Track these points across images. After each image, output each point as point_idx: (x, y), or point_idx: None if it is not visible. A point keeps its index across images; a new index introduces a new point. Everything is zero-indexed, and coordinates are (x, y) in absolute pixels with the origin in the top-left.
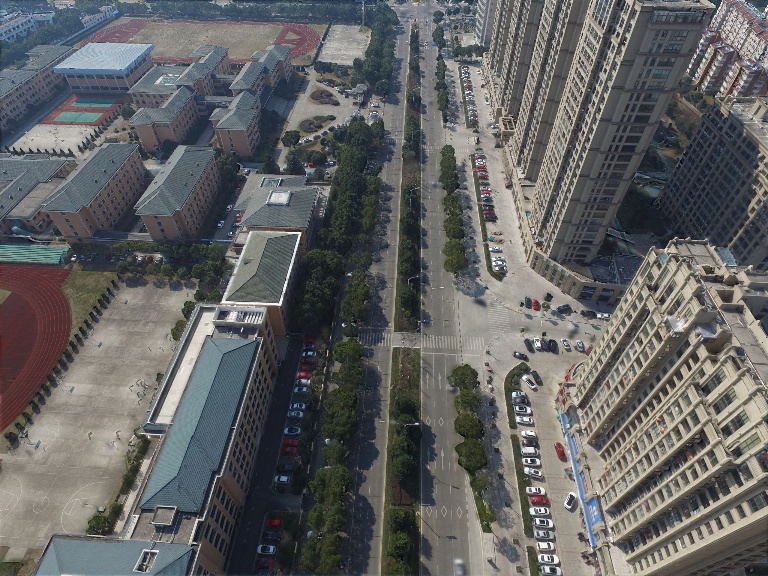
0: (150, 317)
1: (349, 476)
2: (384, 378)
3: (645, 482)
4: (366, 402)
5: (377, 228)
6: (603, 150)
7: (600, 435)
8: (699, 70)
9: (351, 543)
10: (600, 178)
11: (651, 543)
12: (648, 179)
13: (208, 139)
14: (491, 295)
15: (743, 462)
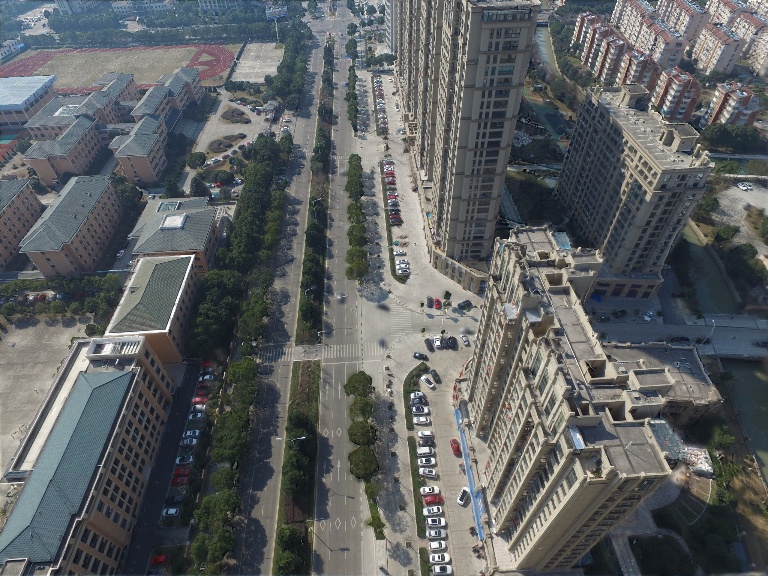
0: (39, 358)
1: (235, 500)
2: (283, 394)
3: (509, 470)
4: (263, 421)
5: (283, 243)
6: (470, 147)
7: (485, 427)
8: (597, 63)
9: (240, 569)
10: (474, 175)
11: (519, 530)
12: (548, 171)
13: (112, 168)
14: (394, 299)
15: (557, 441)
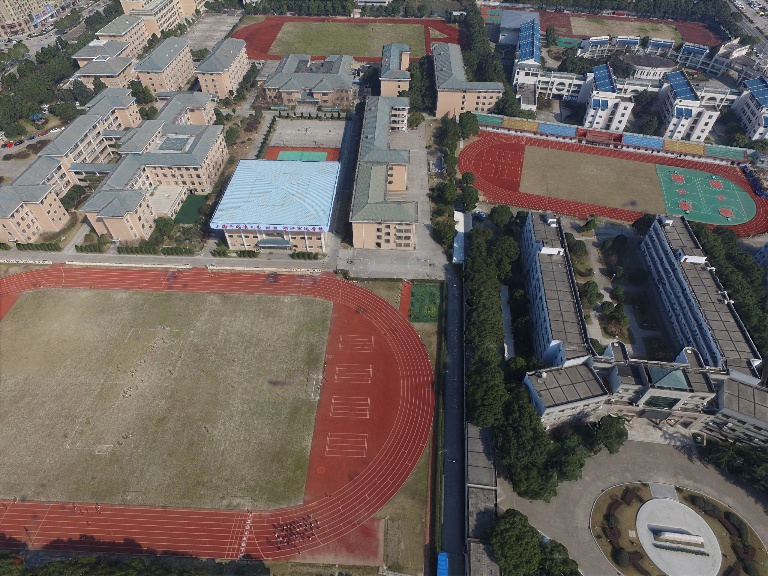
0: None
1: None
2: None
3: None
4: None
5: None
6: None
7: None
8: None
9: None
10: None
11: None
12: None
13: None
14: None
15: None
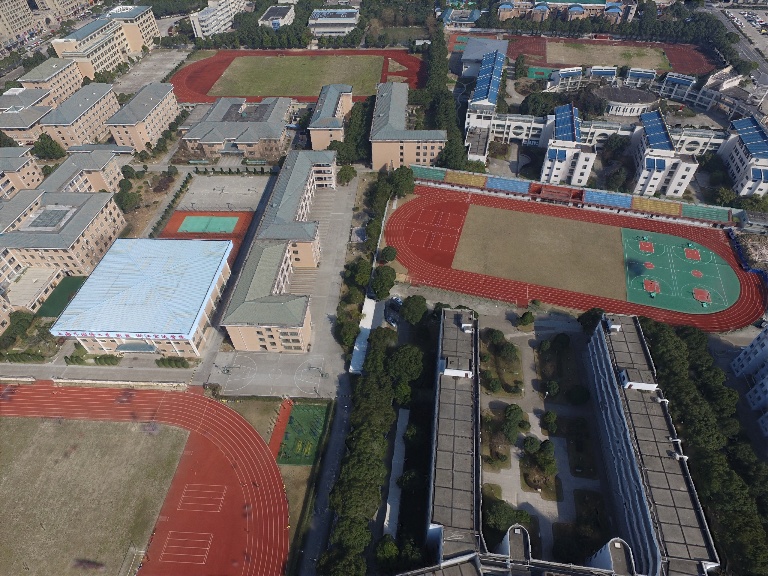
0: None
1: None
2: None
3: None
4: None
5: None
6: None
7: None
8: None
9: None
10: None
11: None
12: None
13: None
14: None
15: None
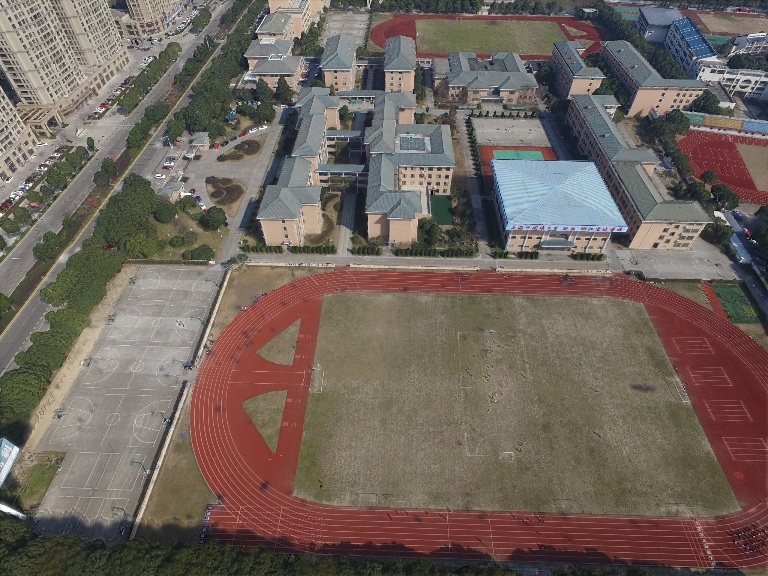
0: None
1: (248, 8)
2: None
3: None
4: None
5: None
6: None
7: None
8: None
9: None
10: None
11: None
12: None
13: None
14: None
15: None
